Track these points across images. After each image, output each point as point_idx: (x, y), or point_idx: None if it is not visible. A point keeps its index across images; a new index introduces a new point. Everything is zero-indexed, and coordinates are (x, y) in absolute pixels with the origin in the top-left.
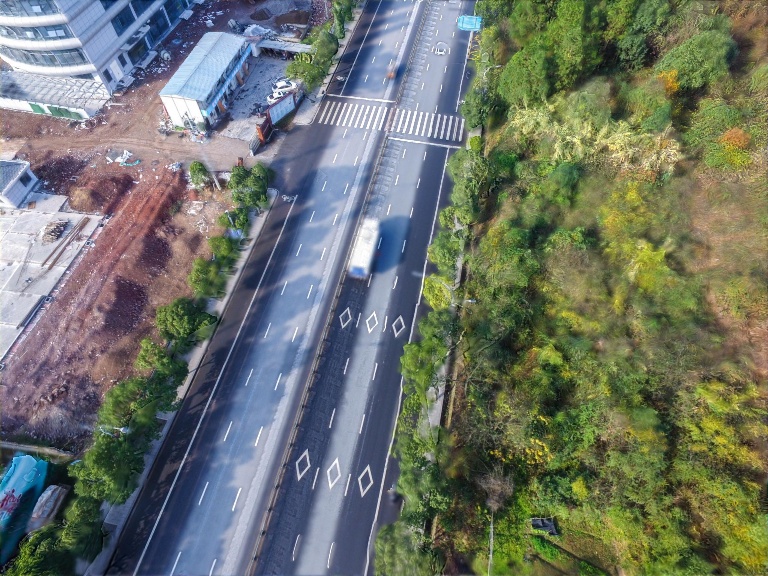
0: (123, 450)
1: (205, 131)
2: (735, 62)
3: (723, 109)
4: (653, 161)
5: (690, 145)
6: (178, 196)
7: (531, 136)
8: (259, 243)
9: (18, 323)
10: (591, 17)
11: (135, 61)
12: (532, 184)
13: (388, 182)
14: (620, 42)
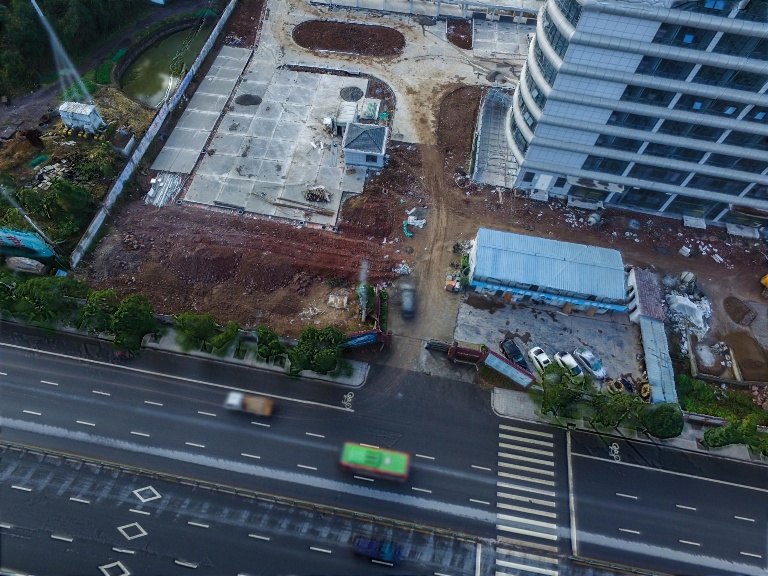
0: (7, 302)
1: (461, 287)
2: None
3: None
4: None
5: None
6: (355, 281)
7: None
8: (278, 376)
9: (219, 200)
10: None
11: (575, 194)
12: None
13: (378, 547)
14: None
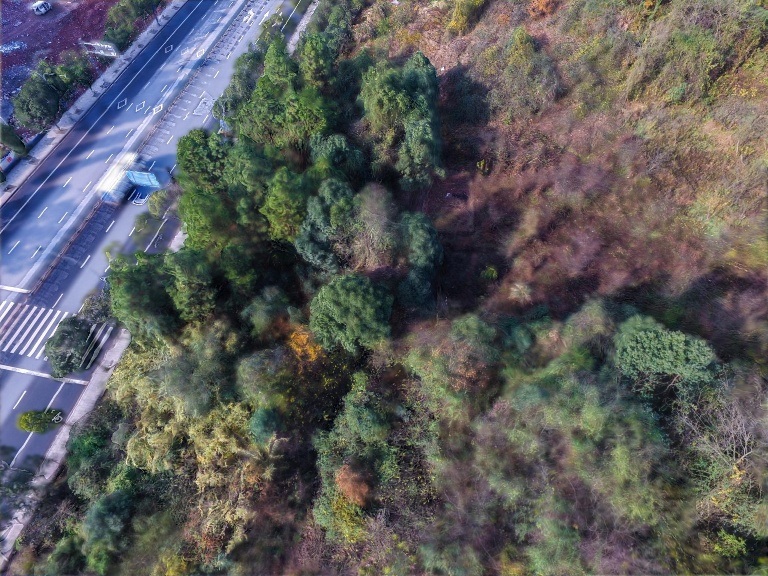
0: None
1: None
2: (484, 254)
3: (353, 416)
4: (219, 518)
5: (316, 461)
6: None
7: (130, 401)
8: None
9: None
10: (240, 213)
11: None
12: (66, 522)
13: None
14: (293, 243)
